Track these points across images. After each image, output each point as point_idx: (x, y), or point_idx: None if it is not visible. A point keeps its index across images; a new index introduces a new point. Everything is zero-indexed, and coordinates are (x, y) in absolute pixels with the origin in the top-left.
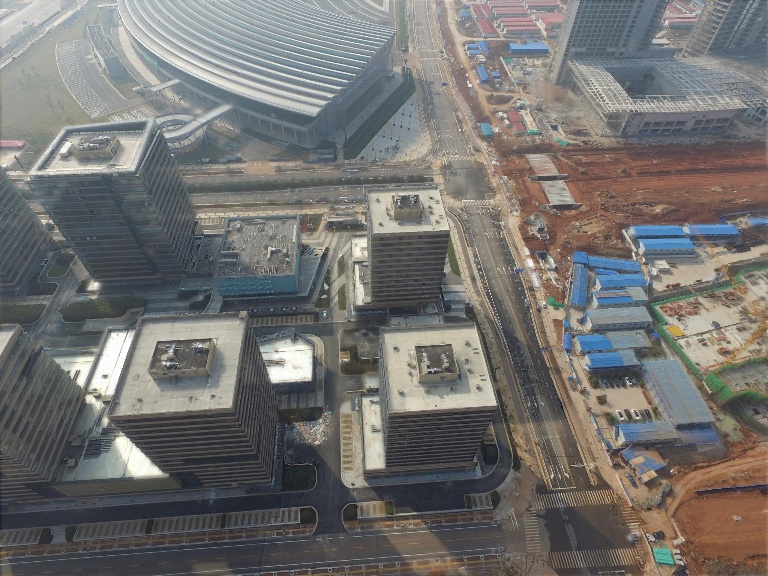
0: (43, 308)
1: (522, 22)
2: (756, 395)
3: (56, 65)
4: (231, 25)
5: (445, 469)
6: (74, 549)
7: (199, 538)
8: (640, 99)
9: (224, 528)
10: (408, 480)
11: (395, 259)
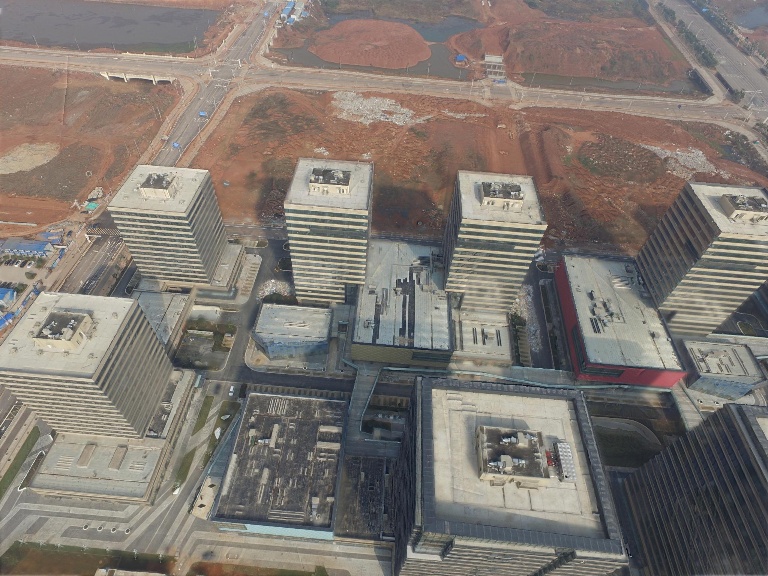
0: None
1: None
2: None
3: None
4: None
5: None
6: None
7: None
8: None
9: None
10: None
11: None
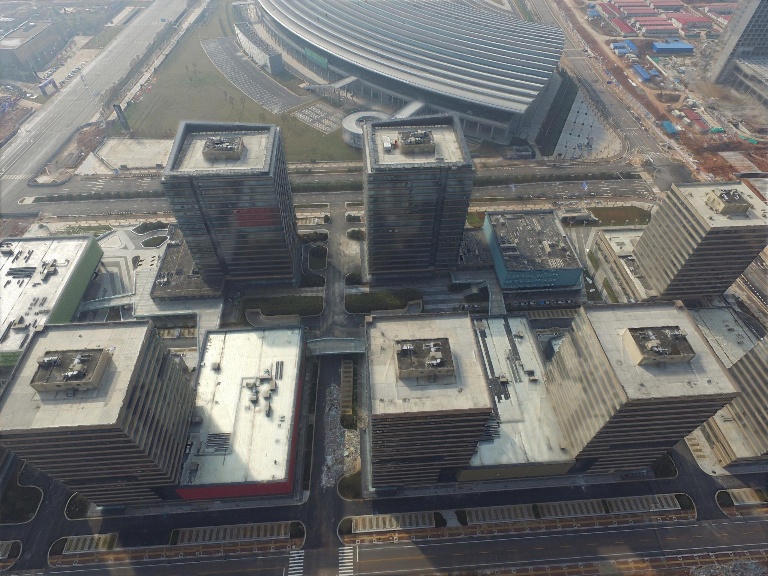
0: (322, 300)
1: (657, 21)
2: None
3: (211, 62)
4: (400, 23)
5: None
6: (472, 532)
7: (589, 523)
8: None
9: (610, 513)
10: (766, 468)
11: (714, 252)
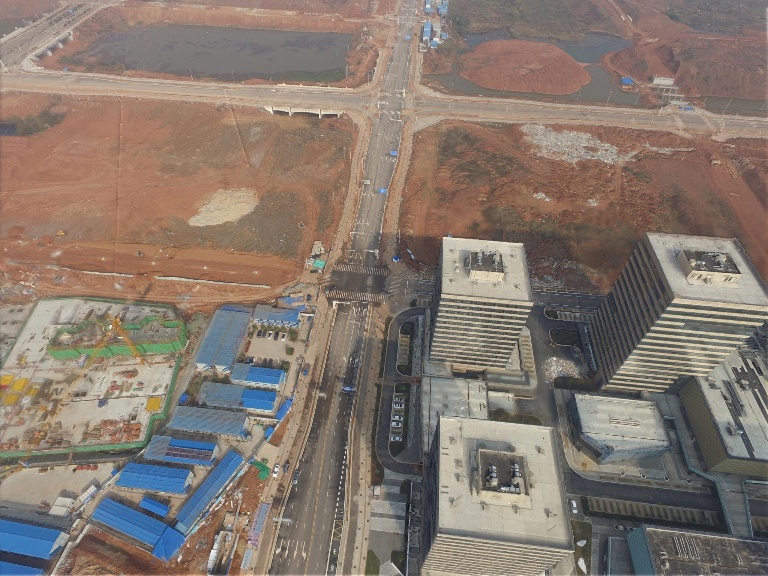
0: None
1: None
2: None
3: None
4: None
5: None
6: None
7: None
8: None
9: None
10: None
11: None
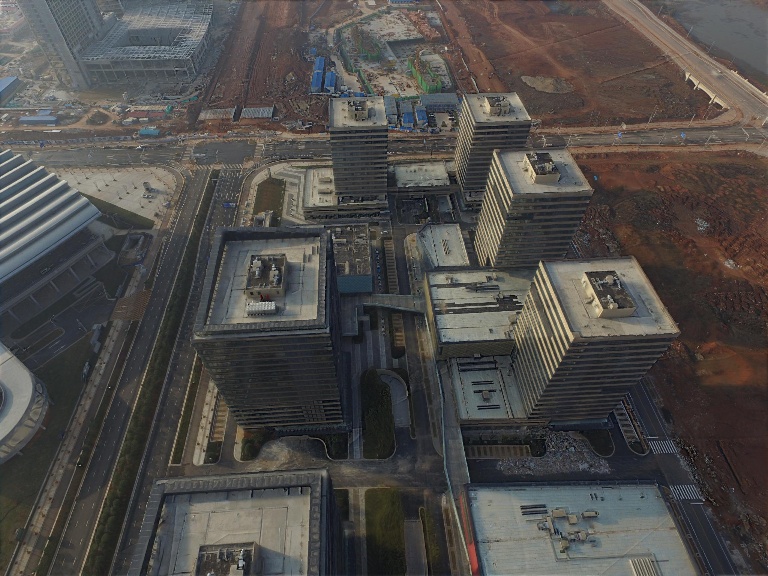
0: (373, 491)
1: None
2: (440, 80)
3: None
4: None
5: None
6: None
7: None
8: (178, 43)
9: None
10: None
11: None
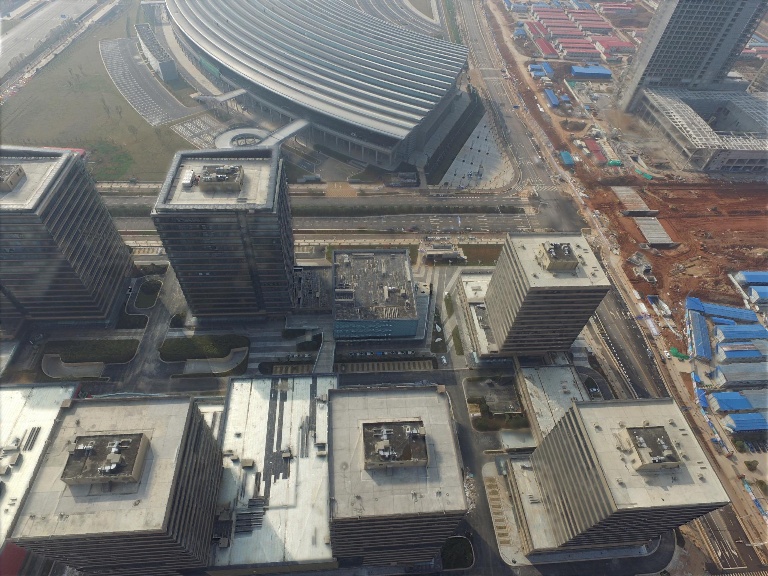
0: (136, 344)
1: (581, 44)
2: None
3: (103, 65)
4: (298, 34)
5: (613, 546)
6: None
7: None
8: (726, 135)
9: None
10: (572, 557)
11: (543, 311)
